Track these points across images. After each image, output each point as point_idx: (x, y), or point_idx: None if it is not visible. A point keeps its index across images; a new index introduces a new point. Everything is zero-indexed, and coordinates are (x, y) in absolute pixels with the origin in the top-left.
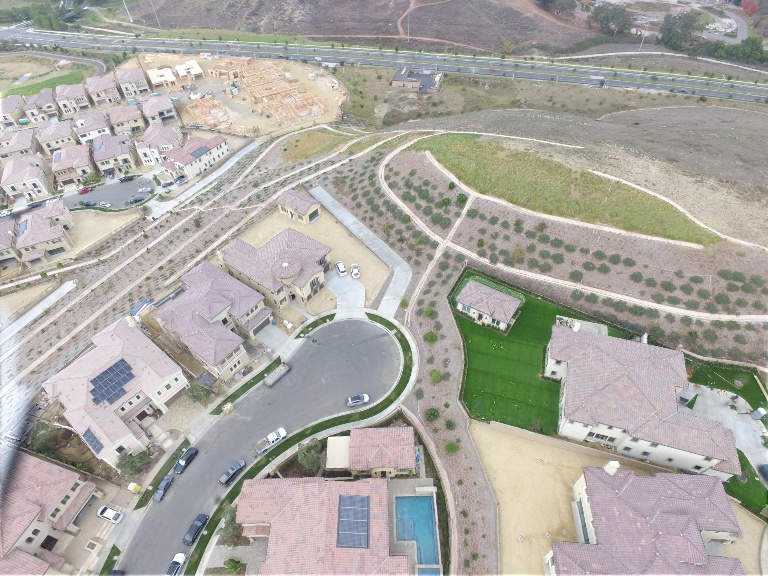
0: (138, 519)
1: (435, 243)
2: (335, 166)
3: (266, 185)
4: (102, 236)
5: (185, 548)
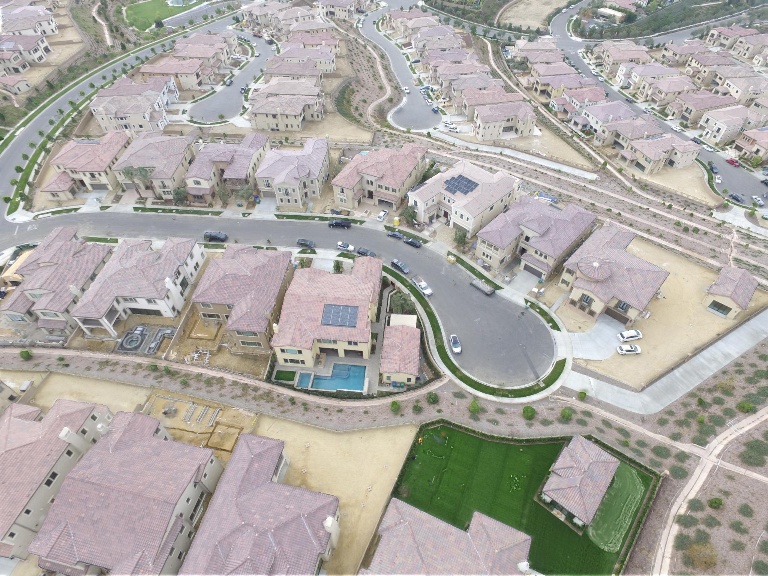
0: (379, 228)
1: (702, 441)
2: None
3: None
4: (672, 188)
5: None
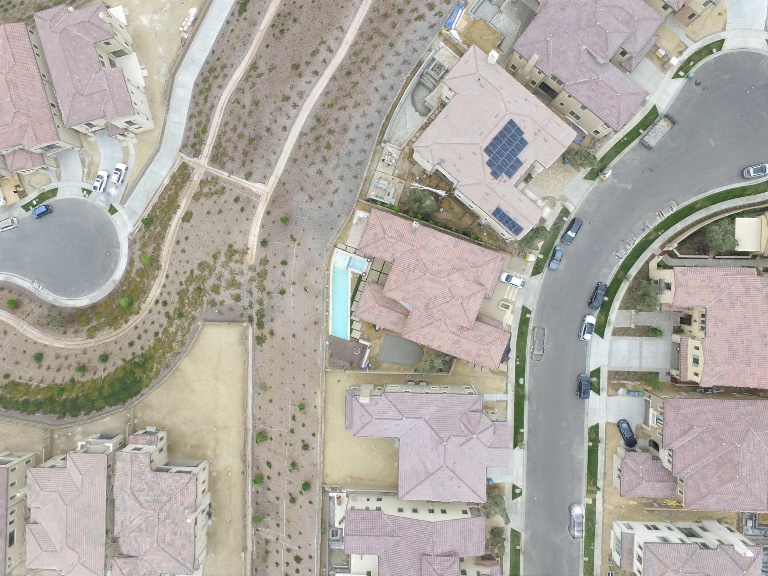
0: (538, 284)
1: None
2: None
3: None
4: None
5: (591, 311)
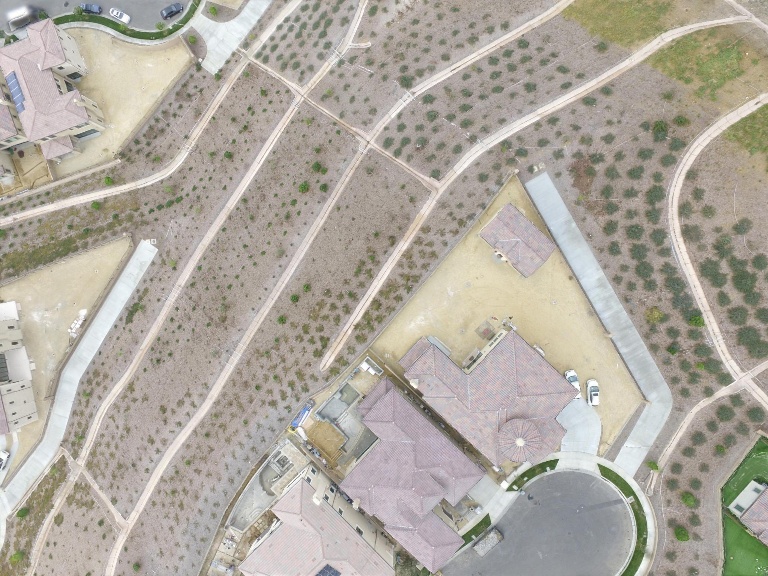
0: None
1: (728, 379)
2: (571, 95)
3: (425, 84)
4: (142, 101)
5: None
